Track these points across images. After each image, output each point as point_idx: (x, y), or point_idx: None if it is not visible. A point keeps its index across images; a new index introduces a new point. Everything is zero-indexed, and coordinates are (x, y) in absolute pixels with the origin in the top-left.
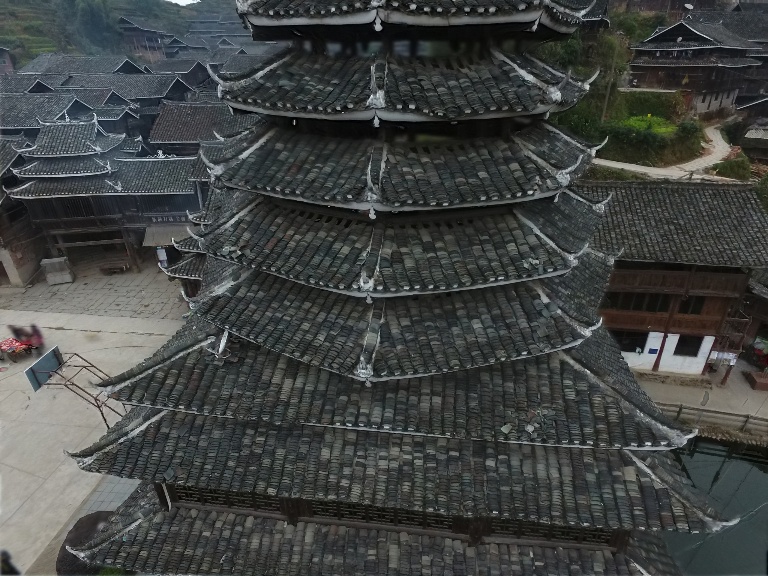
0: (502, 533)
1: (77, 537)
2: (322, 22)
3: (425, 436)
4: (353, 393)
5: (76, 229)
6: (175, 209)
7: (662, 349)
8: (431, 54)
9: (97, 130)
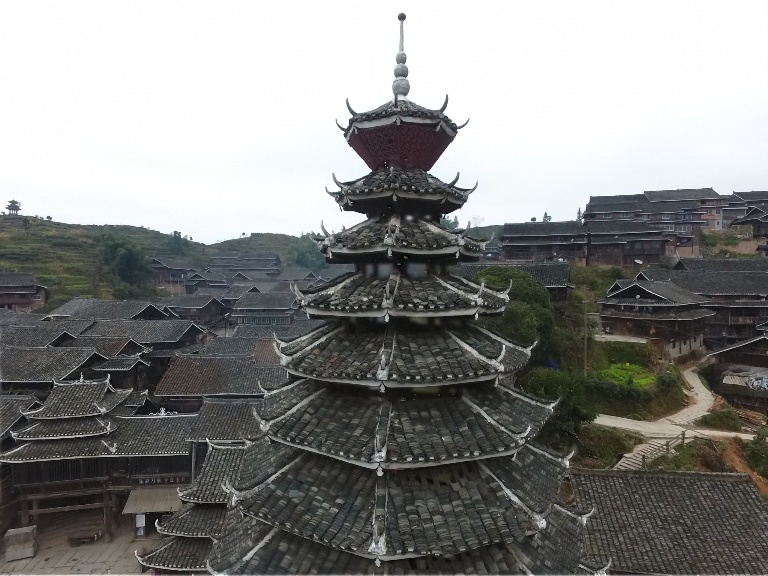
0: None
1: None
2: (332, 456)
3: None
4: None
5: (56, 493)
6: (165, 470)
7: None
8: (426, 468)
9: (107, 389)
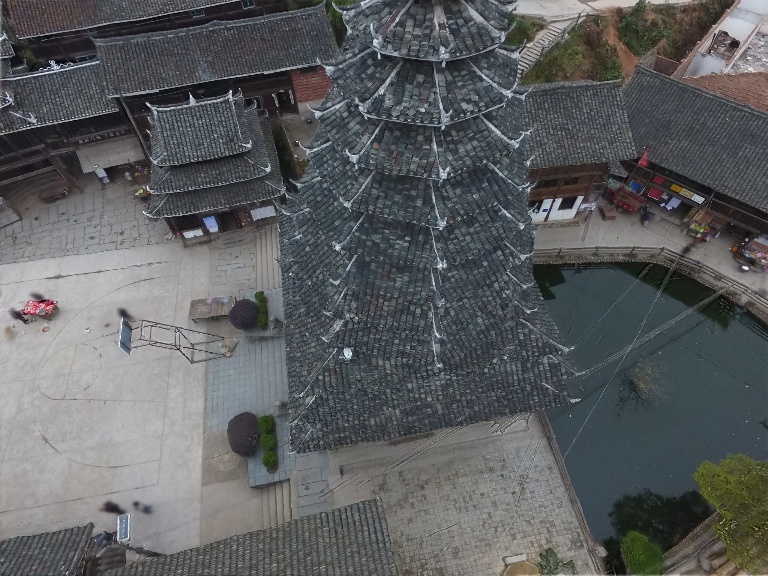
0: None
1: (239, 434)
2: None
3: None
4: None
5: None
6: (101, 128)
7: (551, 208)
8: None
9: None
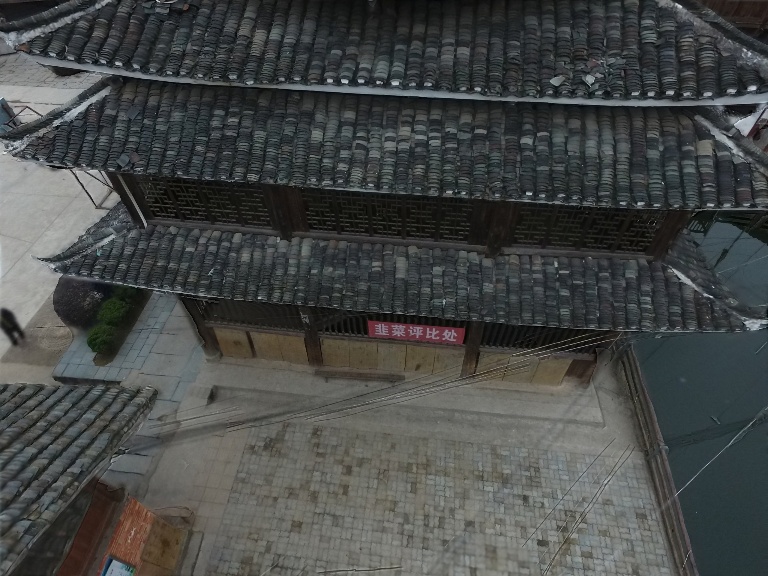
0: (525, 243)
1: (68, 281)
2: None
3: (446, 99)
4: (349, 46)
5: None
6: None
7: None
8: None
9: None
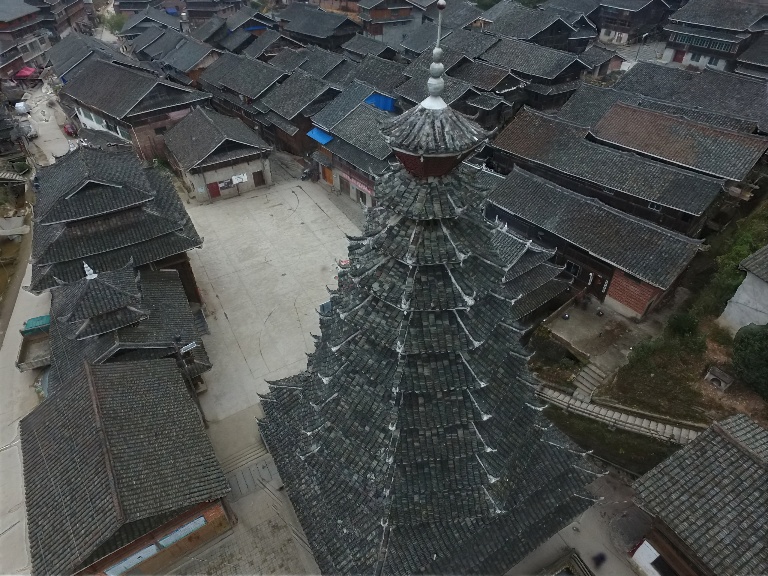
0: None
1: None
2: None
3: None
4: None
5: None
6: None
7: None
8: None
9: None
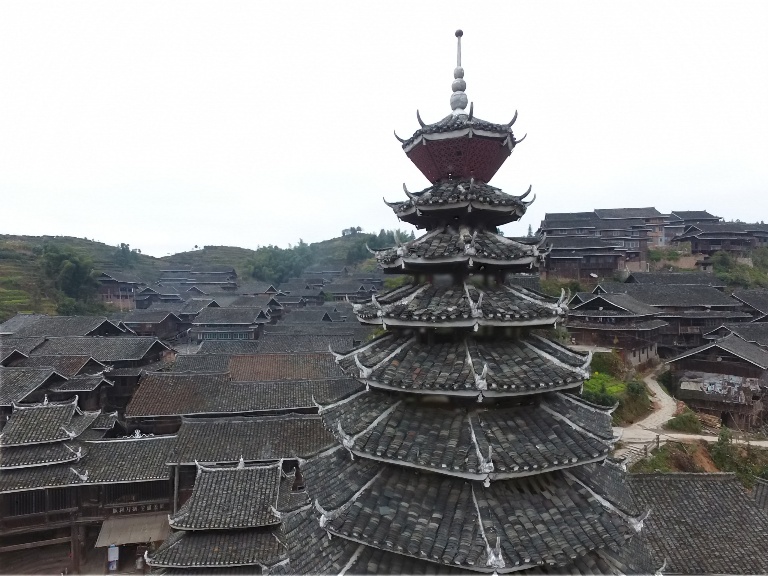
0: None
1: None
2: (430, 469)
3: None
4: None
5: (17, 529)
6: (143, 497)
7: None
8: None
9: (74, 411)
